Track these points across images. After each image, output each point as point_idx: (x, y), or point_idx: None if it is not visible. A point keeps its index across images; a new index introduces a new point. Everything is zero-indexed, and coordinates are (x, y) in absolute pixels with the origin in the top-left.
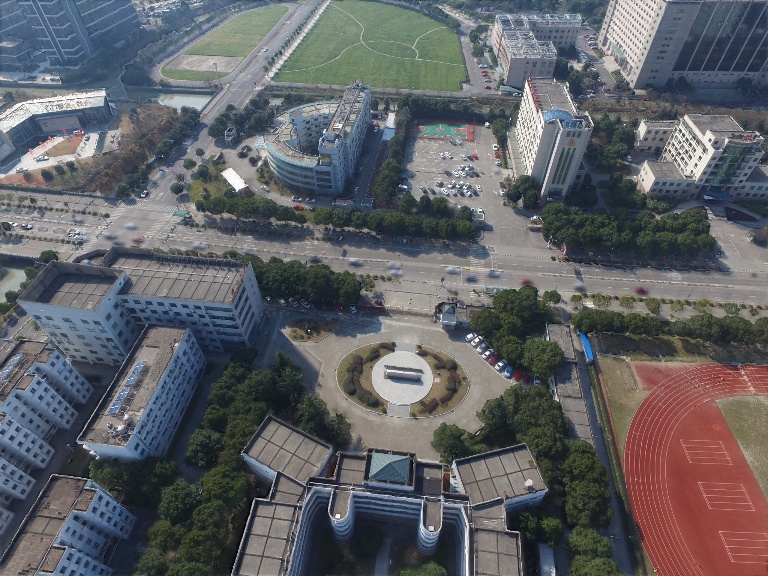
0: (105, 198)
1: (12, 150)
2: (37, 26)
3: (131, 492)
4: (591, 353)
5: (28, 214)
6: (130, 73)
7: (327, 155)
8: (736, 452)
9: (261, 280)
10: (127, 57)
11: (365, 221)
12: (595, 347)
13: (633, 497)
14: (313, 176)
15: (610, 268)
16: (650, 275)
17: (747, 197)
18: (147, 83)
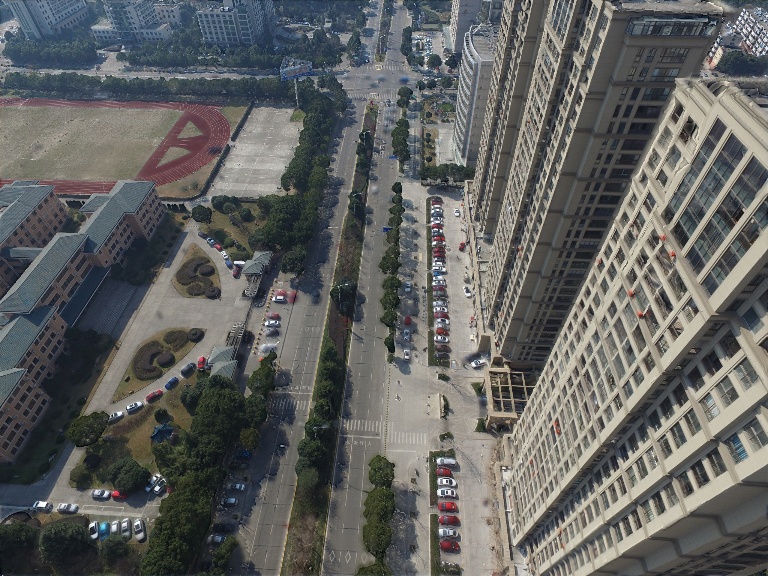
0: None
1: None
2: None
3: None
4: None
5: None
6: None
7: None
8: None
9: None
10: None
11: None
12: None
13: None
14: None
15: (27, 69)
16: (44, 71)
17: (151, 41)
18: None
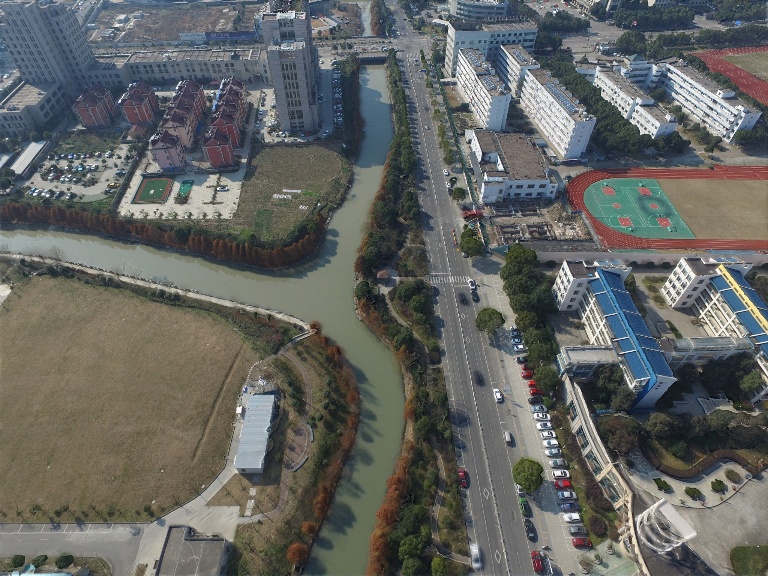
0: (379, 37)
1: None
2: None
3: None
4: None
5: None
6: None
7: None
8: (734, 66)
9: None
10: None
11: None
12: None
13: None
14: (493, 12)
15: (654, 32)
16: None
17: (696, 5)
18: None
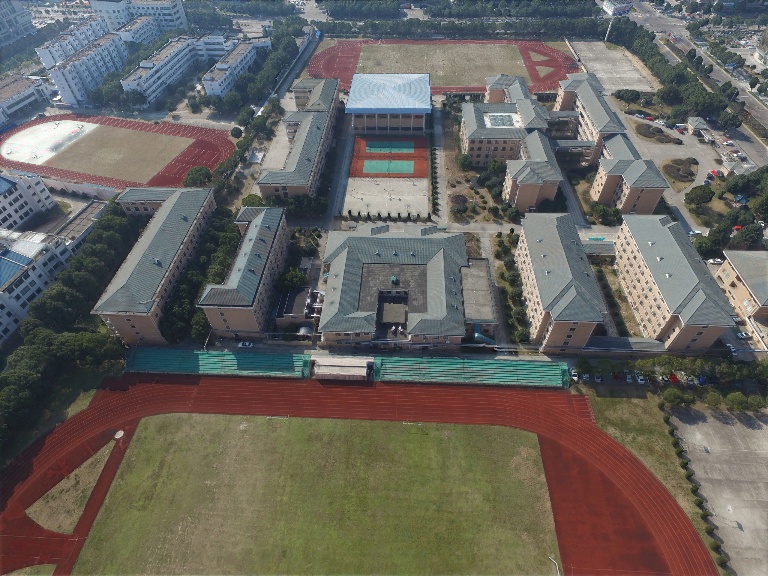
0: None
1: None
2: None
3: (131, 54)
4: (319, 34)
5: None
6: None
7: None
8: (358, 53)
9: (187, 15)
10: None
11: (242, 7)
12: (325, 37)
13: (311, 60)
14: None
15: (350, 21)
16: None
17: (433, 0)
18: None
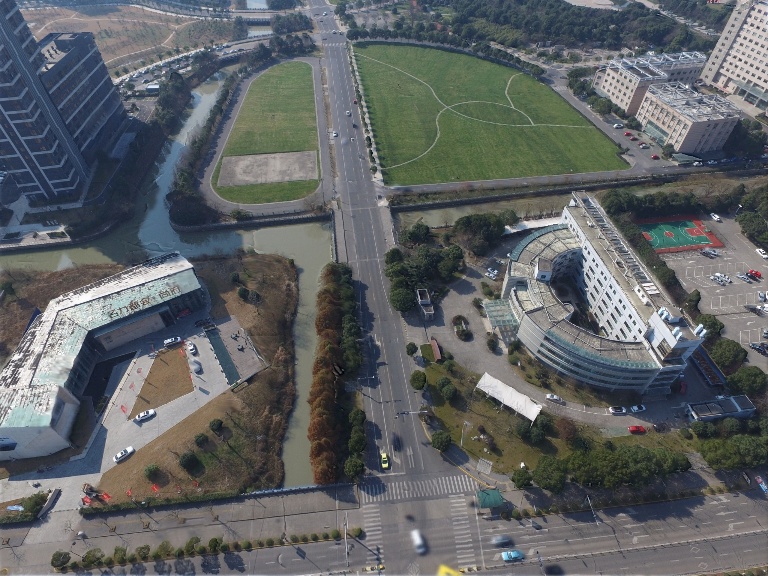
0: (326, 489)
1: (76, 408)
2: (6, 155)
3: None
4: None
5: (211, 572)
6: (187, 209)
7: (681, 348)
8: None
9: None
10: (142, 172)
11: None
12: None
13: None
14: (649, 377)
15: None
16: None
17: None
18: (211, 217)
